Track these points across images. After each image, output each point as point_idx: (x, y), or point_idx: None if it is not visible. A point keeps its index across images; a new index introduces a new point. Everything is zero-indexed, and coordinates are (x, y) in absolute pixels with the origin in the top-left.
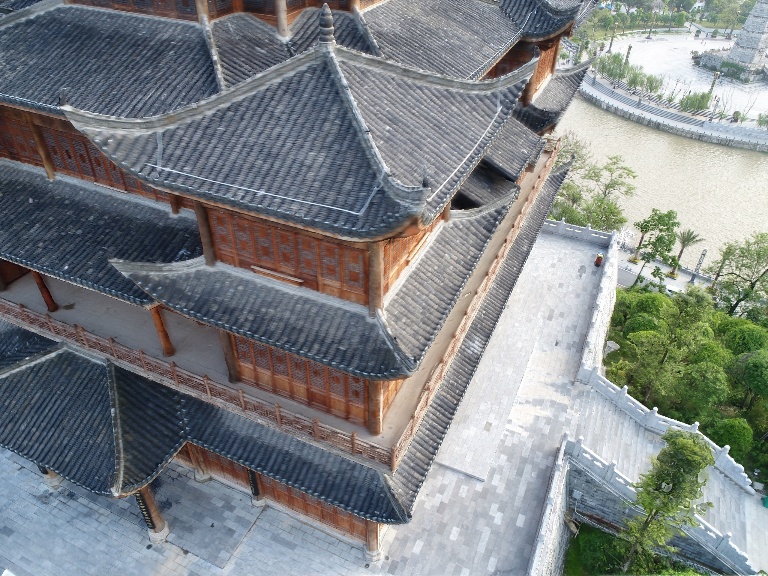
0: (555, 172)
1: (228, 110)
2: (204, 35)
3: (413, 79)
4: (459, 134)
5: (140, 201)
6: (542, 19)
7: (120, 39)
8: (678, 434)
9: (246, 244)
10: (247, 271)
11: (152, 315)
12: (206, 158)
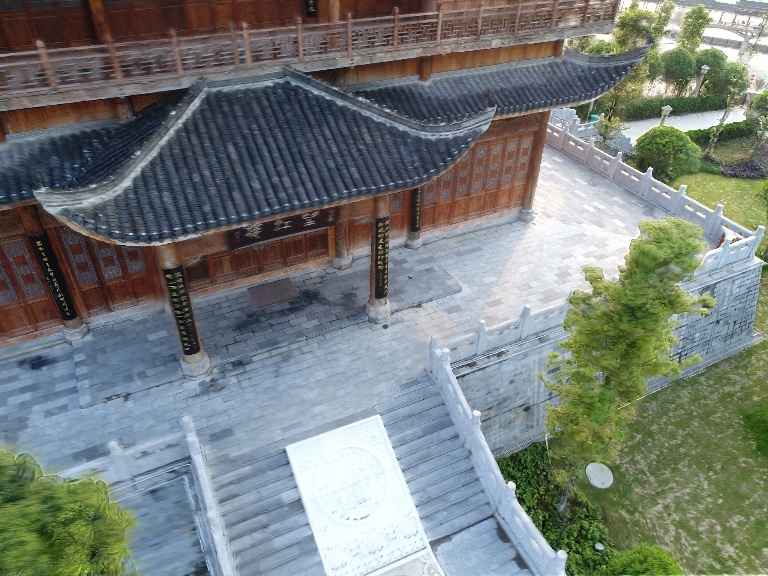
0: None
1: None
2: None
3: None
4: None
5: None
6: None
7: None
8: (625, 16)
9: None
10: None
11: None
12: None
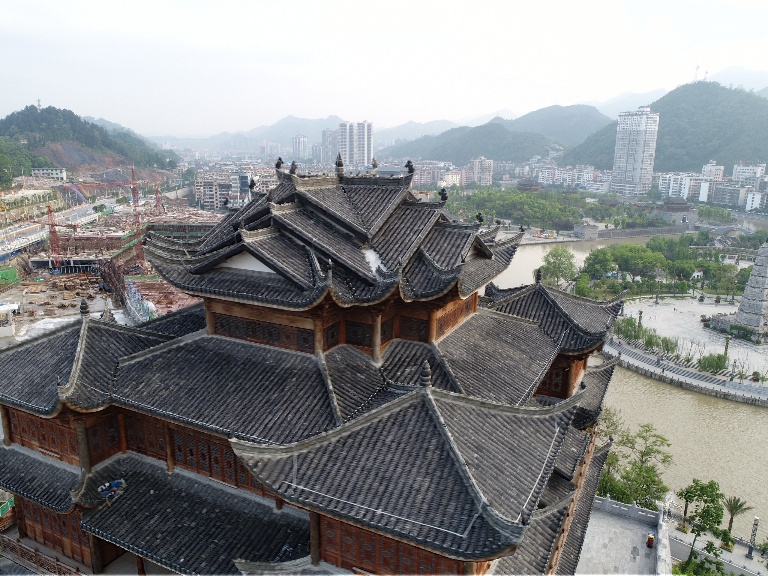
0: (596, 453)
1: (349, 438)
2: (319, 366)
3: (488, 409)
4: (529, 456)
5: (248, 496)
6: (575, 337)
7: (252, 366)
8: None
9: (351, 547)
10: (348, 572)
11: None
12: (332, 478)
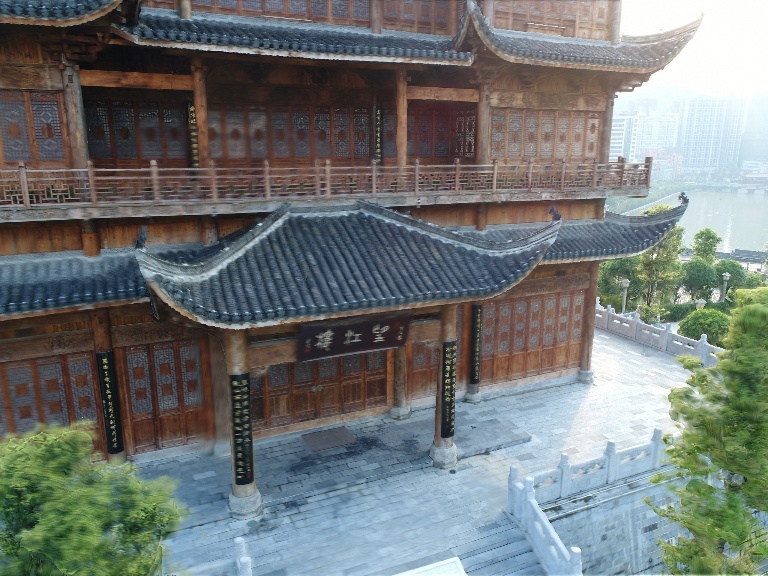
0: None
1: None
2: None
3: None
4: None
5: (330, 29)
6: None
7: None
8: None
9: (522, 0)
10: (520, 31)
11: (402, 130)
12: None
